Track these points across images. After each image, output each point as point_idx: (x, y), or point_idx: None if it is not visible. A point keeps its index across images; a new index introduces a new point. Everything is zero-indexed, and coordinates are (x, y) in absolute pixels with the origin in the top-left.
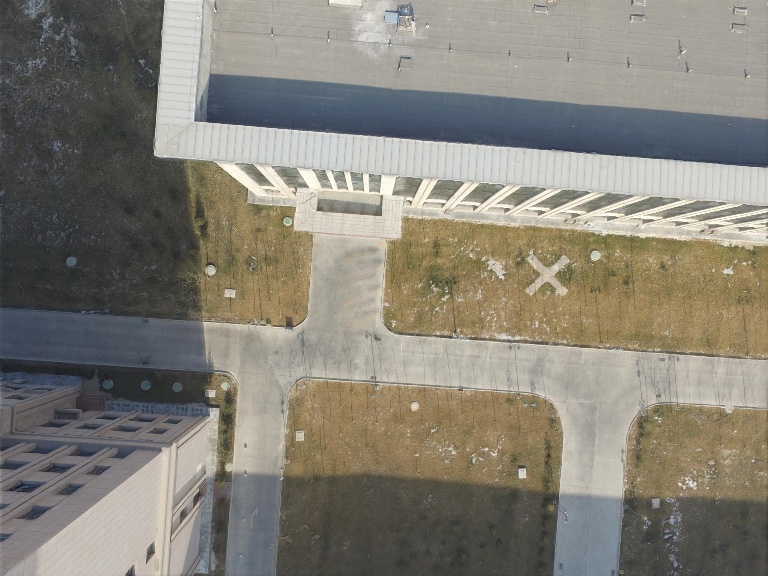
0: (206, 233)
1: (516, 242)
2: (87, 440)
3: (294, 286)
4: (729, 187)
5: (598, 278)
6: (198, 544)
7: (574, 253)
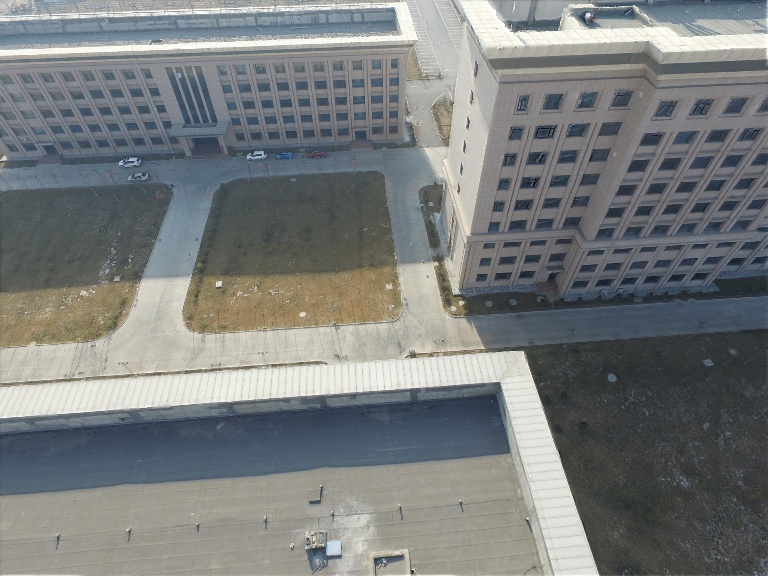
0: None
1: None
2: (523, 237)
3: None
4: (2, 398)
5: None
6: None
7: None
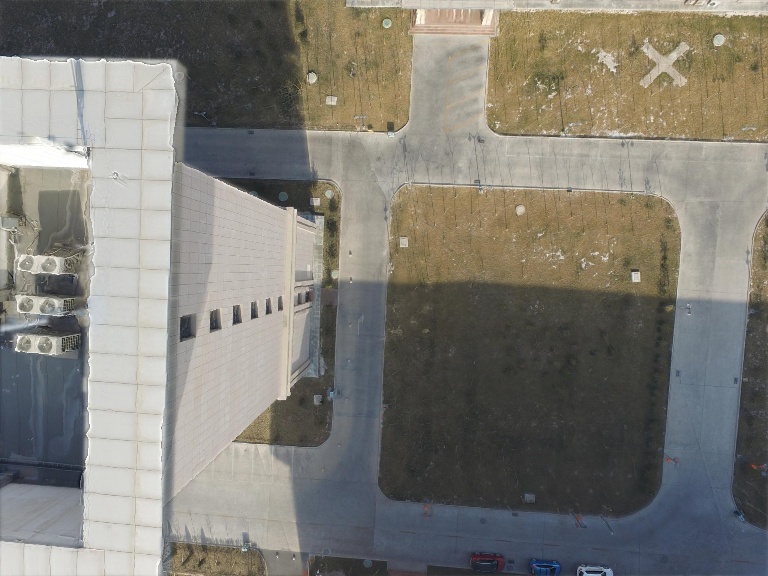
0: (306, 41)
1: (629, 31)
2: None
3: (395, 90)
4: None
5: (721, 65)
6: (308, 347)
7: (694, 39)
